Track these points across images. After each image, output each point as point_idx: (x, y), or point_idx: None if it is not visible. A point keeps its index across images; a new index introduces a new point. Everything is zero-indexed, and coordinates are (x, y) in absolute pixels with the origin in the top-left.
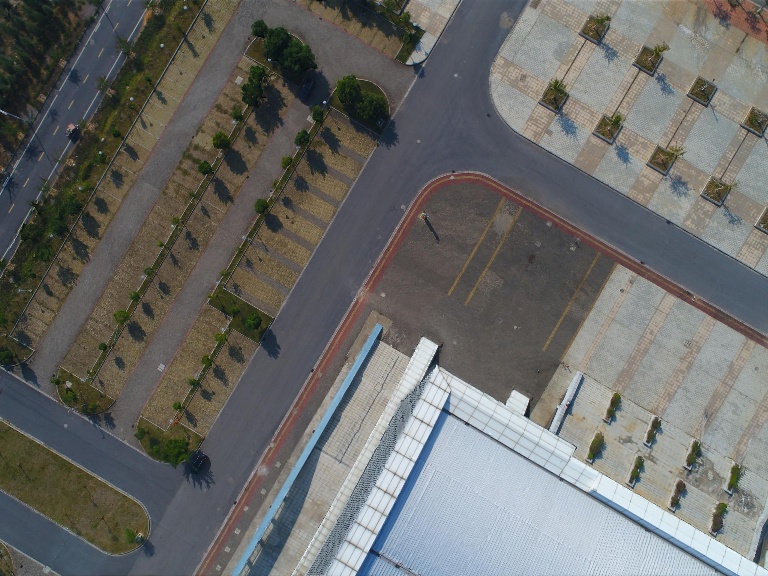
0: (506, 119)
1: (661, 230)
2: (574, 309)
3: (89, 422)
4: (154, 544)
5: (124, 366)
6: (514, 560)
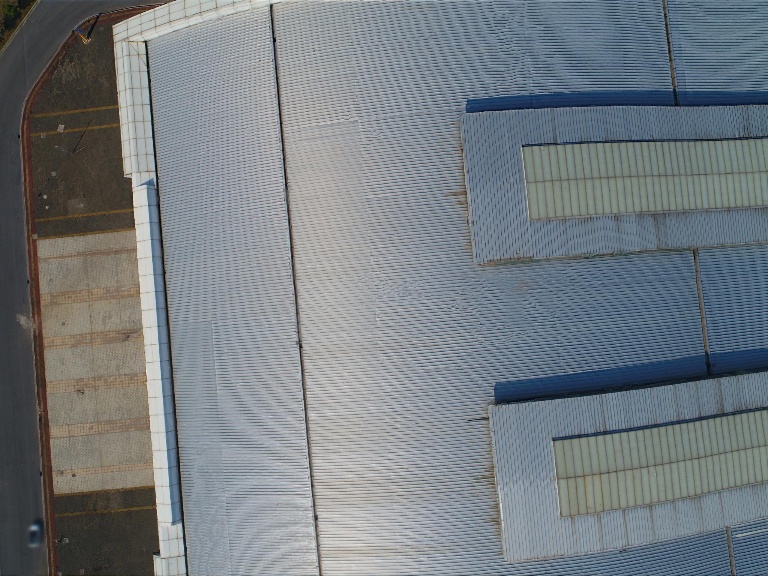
0: None
1: (4, 478)
2: (115, 505)
3: None
4: None
5: None
6: (263, 571)
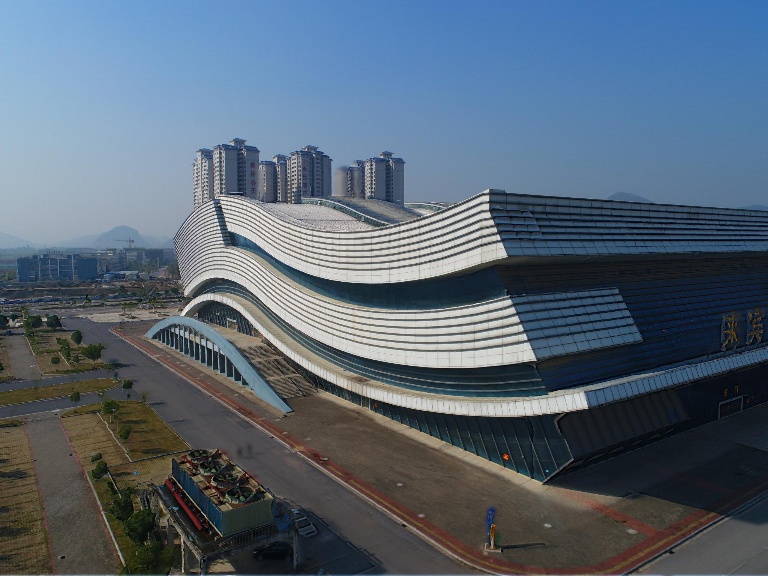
0: (120, 321)
1: None
2: None
3: (0, 384)
4: (131, 379)
5: (1, 372)
6: None
